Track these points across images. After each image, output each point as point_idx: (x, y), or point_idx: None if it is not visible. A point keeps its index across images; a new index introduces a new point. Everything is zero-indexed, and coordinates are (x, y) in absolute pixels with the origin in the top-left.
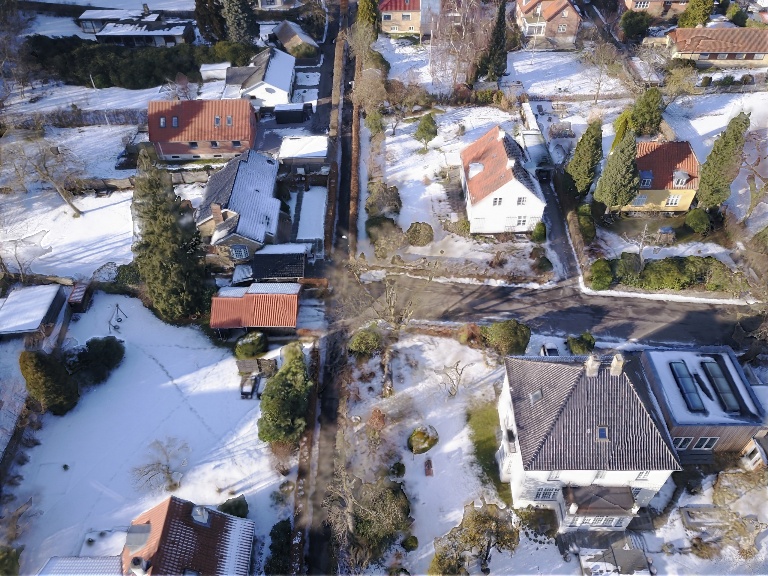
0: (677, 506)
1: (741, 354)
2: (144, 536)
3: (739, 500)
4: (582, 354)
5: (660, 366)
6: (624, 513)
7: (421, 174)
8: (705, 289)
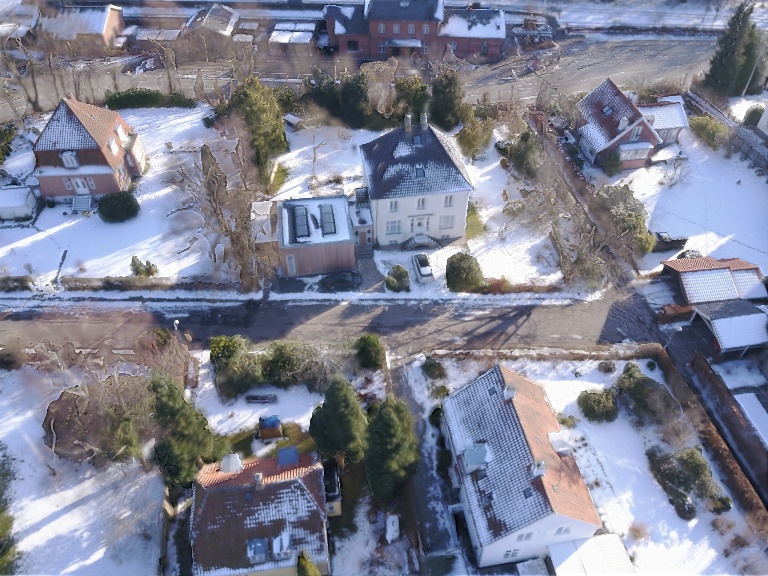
0: None
1: (249, 297)
2: (644, 113)
3: None
4: None
5: (344, 231)
6: None
7: (659, 560)
8: None
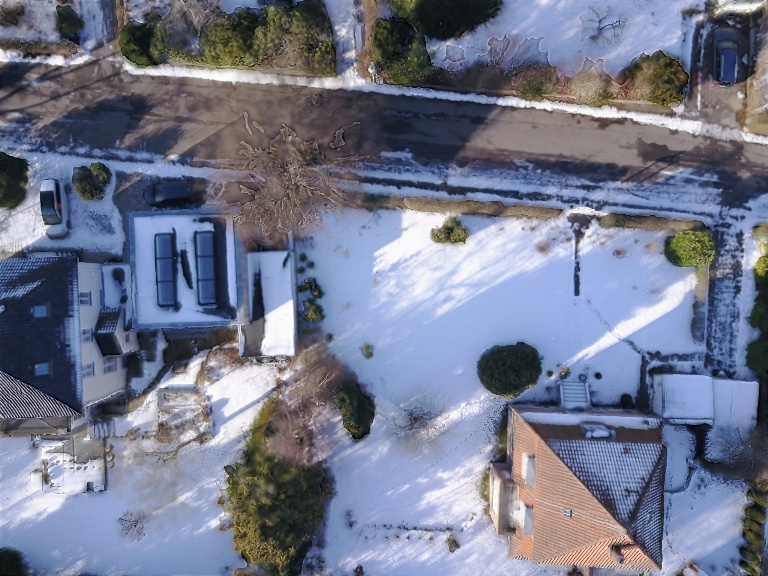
0: (157, 387)
1: None
2: None
3: (217, 383)
4: (83, 198)
5: (142, 239)
6: (54, 432)
7: None
8: (288, 63)
